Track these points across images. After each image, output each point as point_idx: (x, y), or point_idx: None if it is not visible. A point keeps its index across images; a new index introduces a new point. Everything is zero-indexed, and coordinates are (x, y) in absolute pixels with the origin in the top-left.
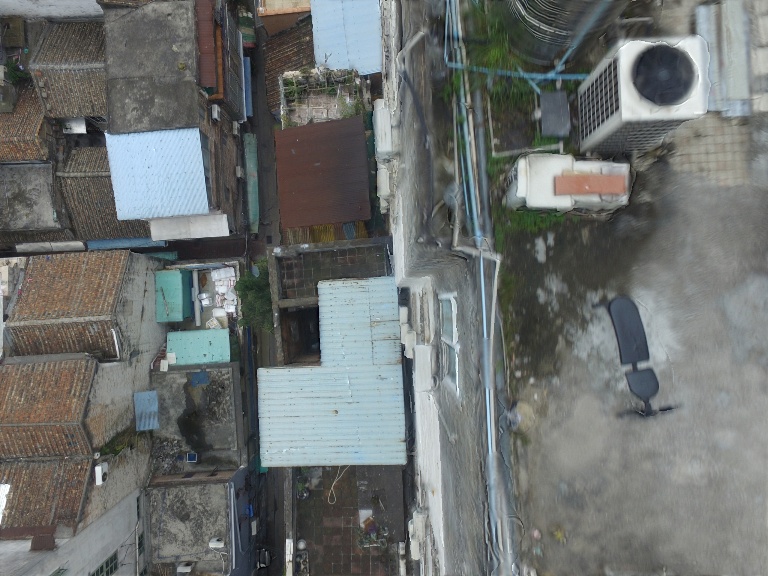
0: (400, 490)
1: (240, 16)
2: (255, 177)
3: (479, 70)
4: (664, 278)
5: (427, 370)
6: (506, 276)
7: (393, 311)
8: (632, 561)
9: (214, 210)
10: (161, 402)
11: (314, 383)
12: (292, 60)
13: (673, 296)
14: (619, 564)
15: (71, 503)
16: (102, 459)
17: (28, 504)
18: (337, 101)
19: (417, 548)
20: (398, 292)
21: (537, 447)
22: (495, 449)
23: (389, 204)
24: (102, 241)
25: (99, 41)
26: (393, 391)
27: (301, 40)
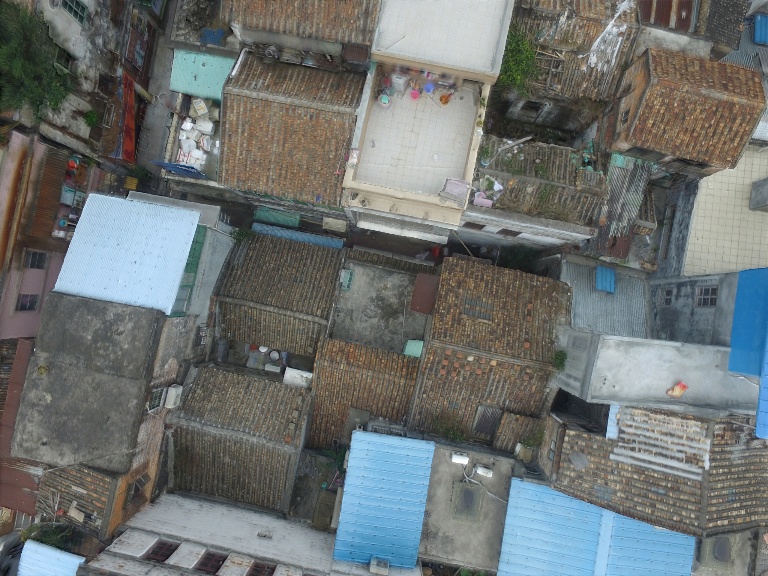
0: None
1: None
2: None
3: None
4: None
5: None
6: None
7: None
8: None
9: None
10: None
11: None
12: None
13: None
14: None
15: None
16: None
17: None
18: None
19: None
20: None
21: None
22: None
23: None
24: None
25: (219, 467)
26: None
27: None
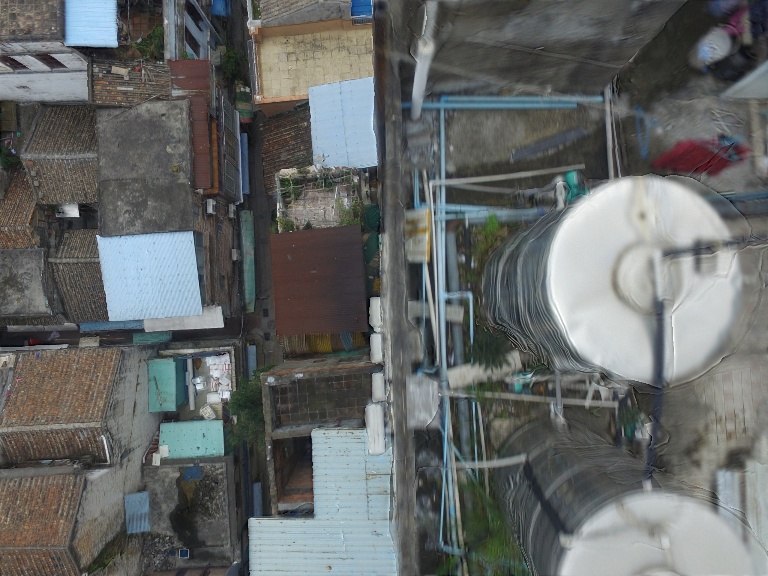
0: None
1: (237, 91)
2: (251, 255)
3: (479, 562)
4: None
5: None
6: None
7: None
8: None
9: (208, 305)
10: (153, 497)
11: (307, 537)
12: (290, 144)
13: None
14: None
15: None
16: None
17: None
18: (335, 203)
19: None
20: None
21: None
22: None
23: None
24: (95, 323)
25: (93, 127)
26: (389, 548)
27: (299, 125)
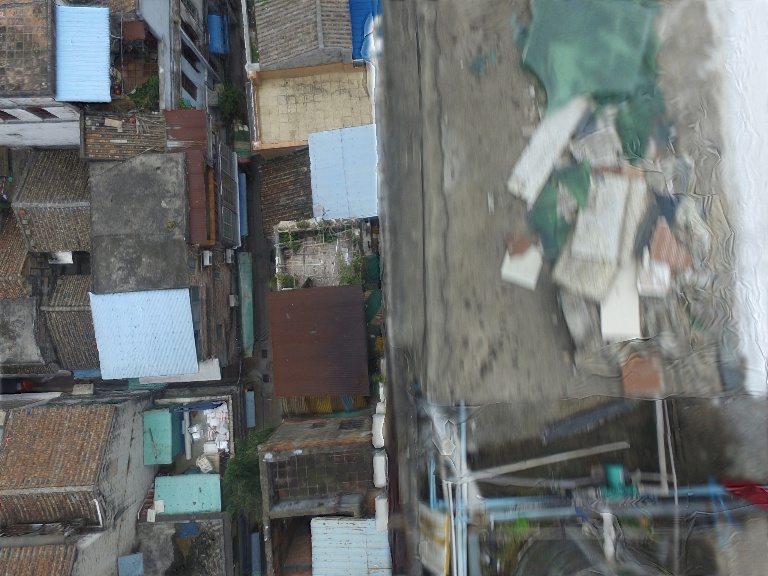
0: None
1: (236, 131)
2: (250, 298)
3: None
4: None
5: None
6: None
7: None
8: None
9: (205, 360)
10: (148, 554)
11: None
12: (289, 188)
13: None
14: None
15: None
16: None
17: None
18: (335, 258)
19: None
20: None
21: None
22: None
23: None
24: (89, 369)
25: (86, 173)
26: None
27: (298, 169)
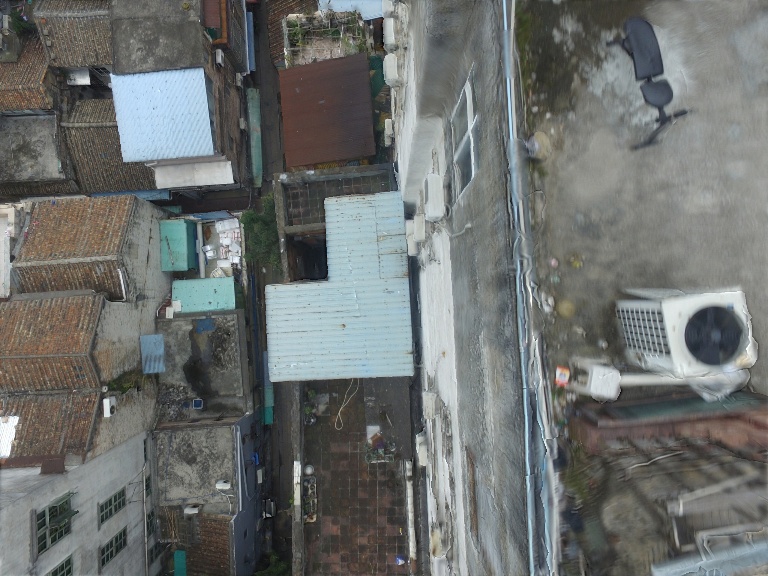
0: (407, 406)
1: None
2: (258, 132)
3: None
4: (676, 16)
5: (440, 197)
6: (523, 14)
7: (399, 225)
8: (647, 282)
9: (218, 155)
10: (167, 349)
11: (321, 298)
12: (295, 10)
13: (685, 32)
14: (634, 284)
15: (80, 433)
16: (110, 394)
17: (37, 435)
18: (341, 41)
19: (425, 454)
20: (404, 206)
21: (554, 180)
22: (516, 134)
23: (394, 131)
24: (106, 194)
25: None
26: (400, 304)
27: None
